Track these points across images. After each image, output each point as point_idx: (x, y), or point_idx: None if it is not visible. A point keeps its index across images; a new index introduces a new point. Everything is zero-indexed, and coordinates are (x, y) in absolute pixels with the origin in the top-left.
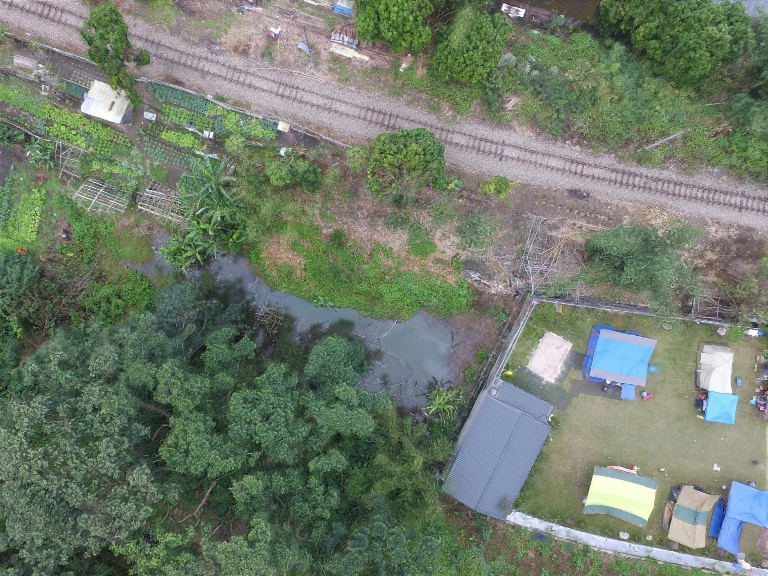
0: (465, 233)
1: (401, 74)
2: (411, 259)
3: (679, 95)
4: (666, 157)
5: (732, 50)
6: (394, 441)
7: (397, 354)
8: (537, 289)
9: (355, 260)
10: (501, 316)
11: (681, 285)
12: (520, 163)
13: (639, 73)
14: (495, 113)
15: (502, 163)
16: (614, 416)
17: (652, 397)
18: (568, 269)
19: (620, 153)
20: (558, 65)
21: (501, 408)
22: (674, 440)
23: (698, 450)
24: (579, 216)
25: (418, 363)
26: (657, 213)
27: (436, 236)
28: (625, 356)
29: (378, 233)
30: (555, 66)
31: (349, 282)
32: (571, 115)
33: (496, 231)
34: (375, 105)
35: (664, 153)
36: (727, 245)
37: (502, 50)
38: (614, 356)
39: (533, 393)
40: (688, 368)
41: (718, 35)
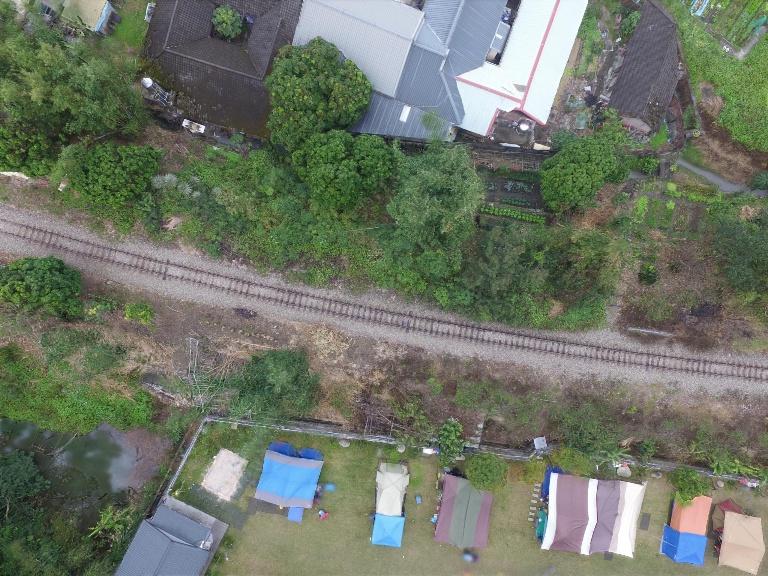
0: (142, 347)
1: (57, 194)
2: (88, 373)
3: (342, 217)
4: (331, 278)
5: (367, 183)
6: (35, 570)
7: (80, 467)
8: (208, 407)
9: (30, 373)
10: (176, 432)
11: (366, 400)
12: (184, 282)
13: (306, 194)
14: (155, 233)
15: (166, 282)
16: (292, 534)
17: (331, 515)
18: (239, 387)
19: (287, 273)
20: (221, 186)
21: (154, 534)
22: (354, 559)
23: (379, 569)
24: (243, 336)
25: (102, 476)
26: (322, 333)
27: (113, 350)
28: (287, 478)
29: (53, 346)
30: (218, 187)
31: (23, 396)
32: (231, 237)
33: (168, 347)
34: (36, 223)
35: (328, 274)
36: (393, 366)
37: (147, 176)
38: (278, 478)
39: (208, 511)
40: (368, 485)
41: (330, 175)
